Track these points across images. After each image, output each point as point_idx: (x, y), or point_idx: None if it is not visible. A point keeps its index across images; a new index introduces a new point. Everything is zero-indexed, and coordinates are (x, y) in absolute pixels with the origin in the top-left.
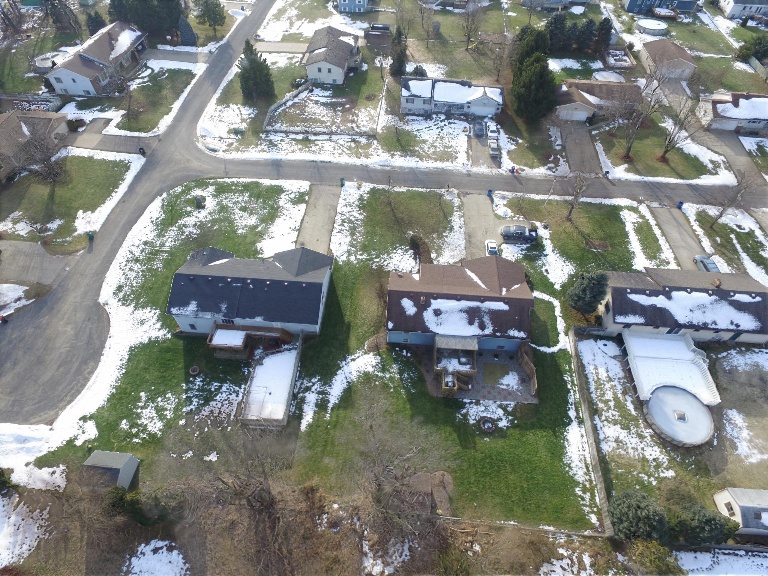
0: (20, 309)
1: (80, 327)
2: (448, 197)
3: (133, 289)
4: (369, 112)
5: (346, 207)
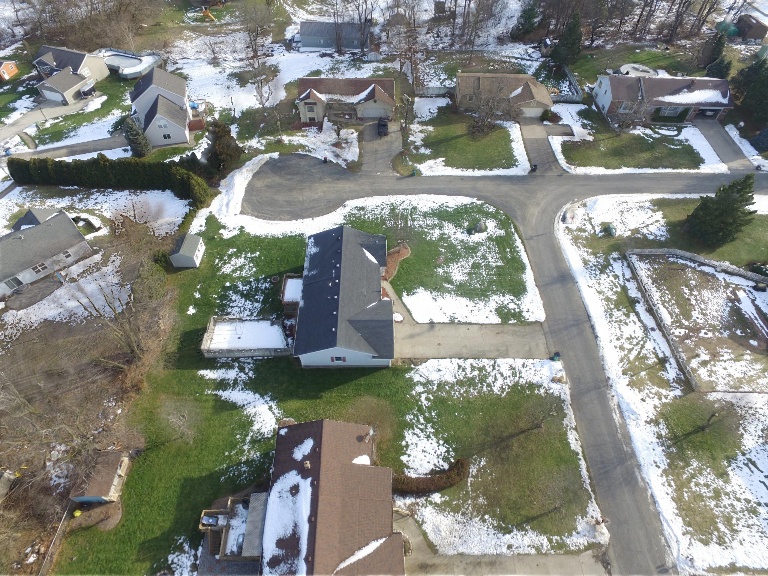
0: (338, 165)
1: (321, 199)
2: (582, 524)
3: (361, 217)
4: (759, 376)
5: (509, 369)
